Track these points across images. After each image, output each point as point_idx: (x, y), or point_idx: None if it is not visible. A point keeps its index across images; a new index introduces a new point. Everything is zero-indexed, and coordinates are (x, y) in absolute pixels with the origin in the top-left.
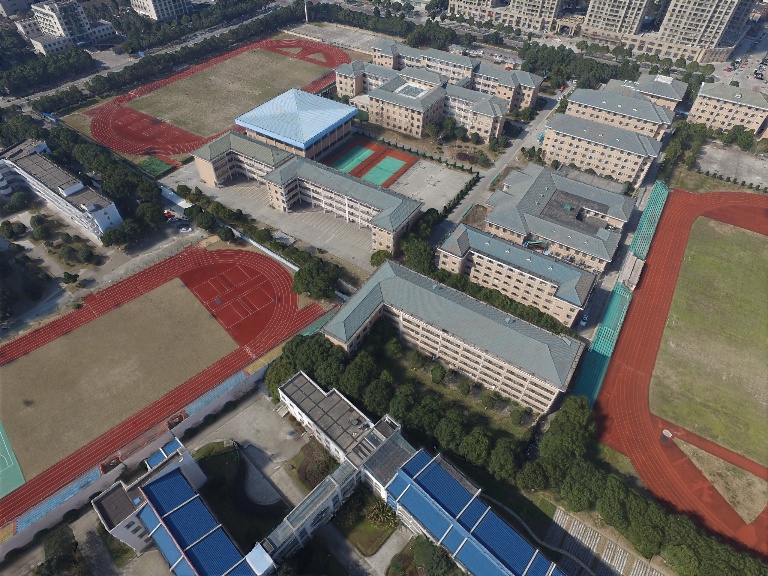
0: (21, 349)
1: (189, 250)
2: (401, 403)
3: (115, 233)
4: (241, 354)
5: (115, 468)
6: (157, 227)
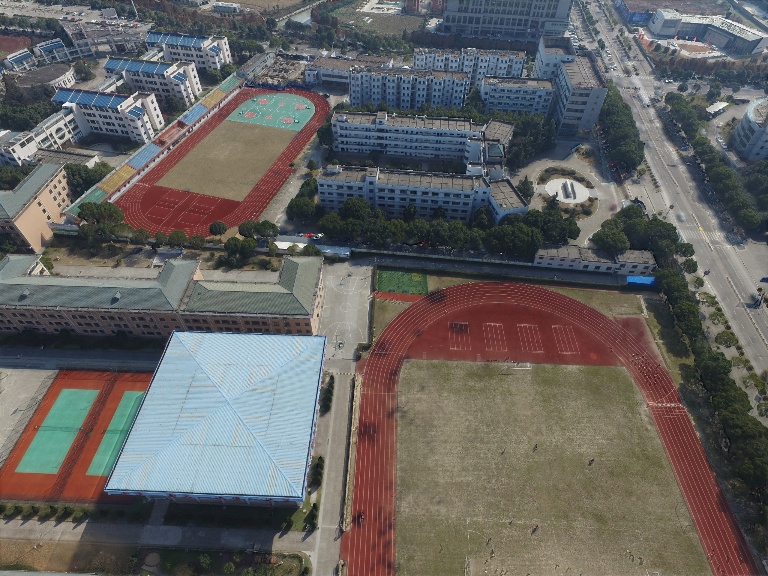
0: (297, 143)
1: (253, 220)
2: (5, 166)
3: (305, 182)
4: (150, 182)
5: (174, 121)
6: (306, 225)
